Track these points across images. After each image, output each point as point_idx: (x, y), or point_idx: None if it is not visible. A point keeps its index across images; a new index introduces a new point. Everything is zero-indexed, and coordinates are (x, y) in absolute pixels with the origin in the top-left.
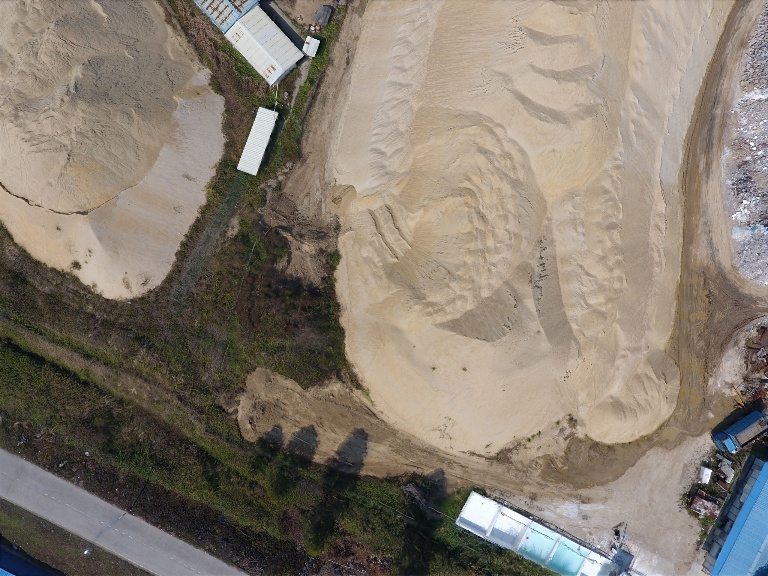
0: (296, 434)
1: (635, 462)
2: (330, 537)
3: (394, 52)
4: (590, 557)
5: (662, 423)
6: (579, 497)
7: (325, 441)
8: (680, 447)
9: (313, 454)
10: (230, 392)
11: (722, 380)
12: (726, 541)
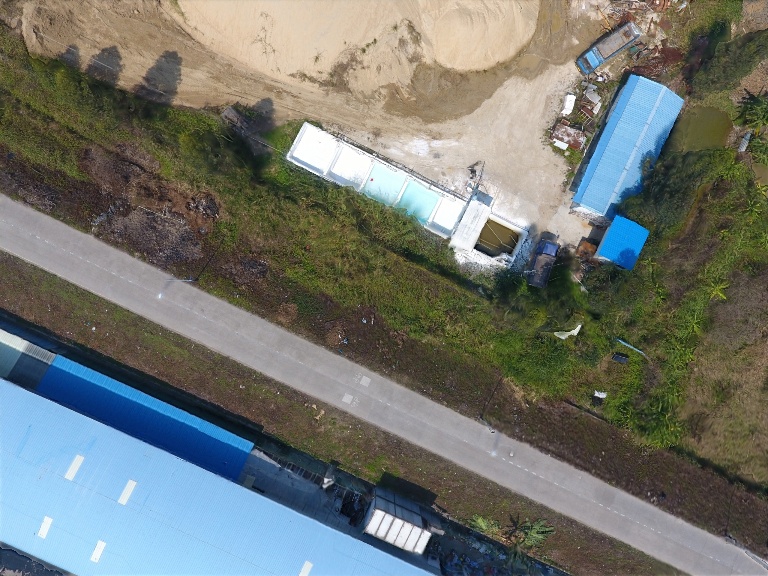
0: (96, 57)
1: (492, 93)
2: (100, 98)
3: None
4: (445, 203)
5: (521, 49)
6: (429, 132)
7: (131, 65)
8: (542, 77)
9: (117, 80)
10: (12, 1)
11: (587, 2)
12: (590, 163)
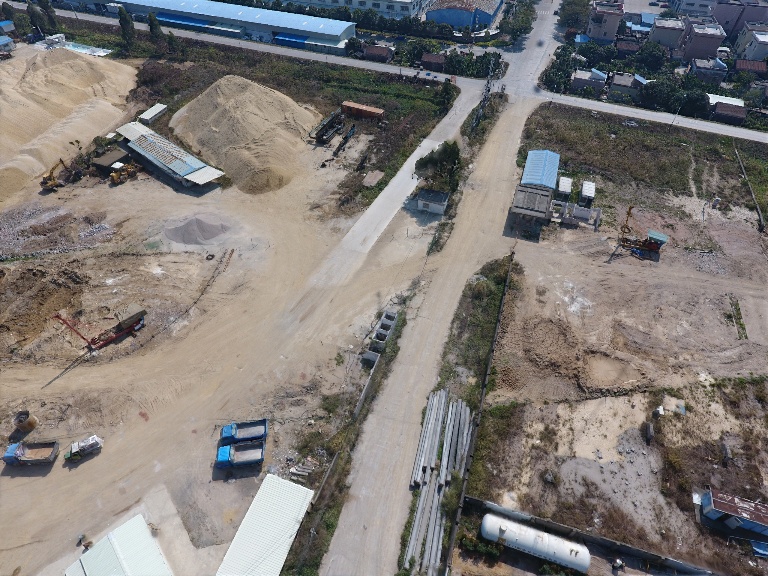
0: None
1: None
2: None
3: (64, 130)
4: None
5: None
6: None
7: None
8: None
9: None
10: None
11: None
12: (0, 44)
